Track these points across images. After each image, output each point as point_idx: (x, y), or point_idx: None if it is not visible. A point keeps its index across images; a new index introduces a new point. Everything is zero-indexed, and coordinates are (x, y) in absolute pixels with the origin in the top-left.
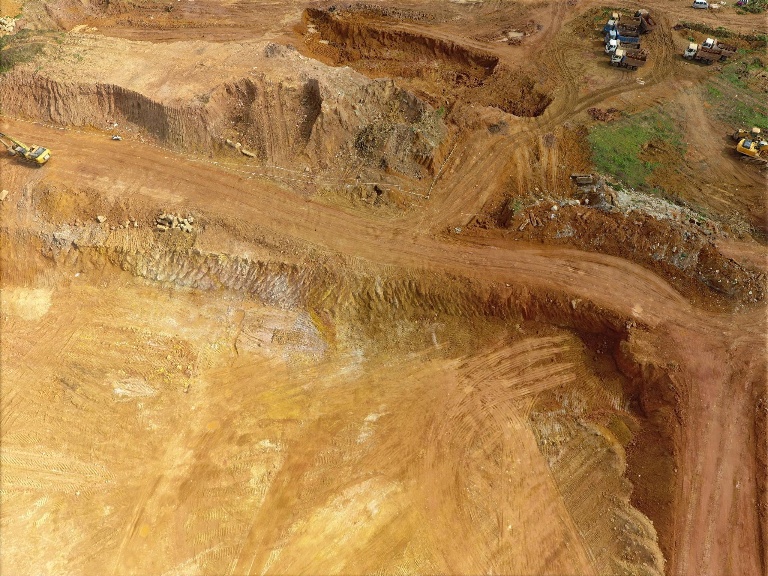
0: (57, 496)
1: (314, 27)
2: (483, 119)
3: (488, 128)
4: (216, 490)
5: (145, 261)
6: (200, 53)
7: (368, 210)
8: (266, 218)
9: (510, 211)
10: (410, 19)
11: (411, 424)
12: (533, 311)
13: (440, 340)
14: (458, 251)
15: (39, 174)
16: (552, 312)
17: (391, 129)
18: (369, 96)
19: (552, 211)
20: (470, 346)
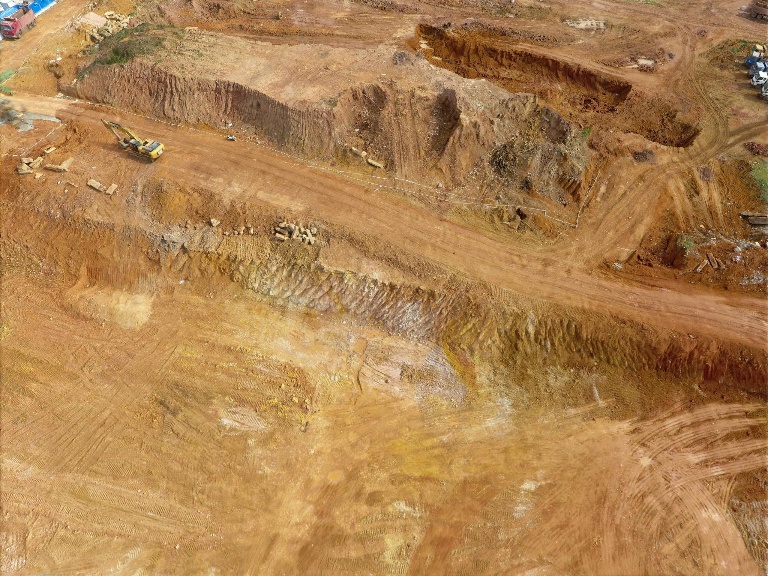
0: (153, 547)
1: (426, 43)
2: (626, 146)
3: (633, 156)
4: (343, 561)
5: (259, 273)
6: (324, 57)
7: (511, 235)
8: (397, 235)
9: (680, 249)
10: (531, 40)
11: (579, 499)
12: (719, 370)
13: (603, 395)
14: (623, 290)
15: (150, 170)
16: (745, 374)
17: (535, 148)
18: (508, 111)
19: (736, 252)
20: (641, 406)
